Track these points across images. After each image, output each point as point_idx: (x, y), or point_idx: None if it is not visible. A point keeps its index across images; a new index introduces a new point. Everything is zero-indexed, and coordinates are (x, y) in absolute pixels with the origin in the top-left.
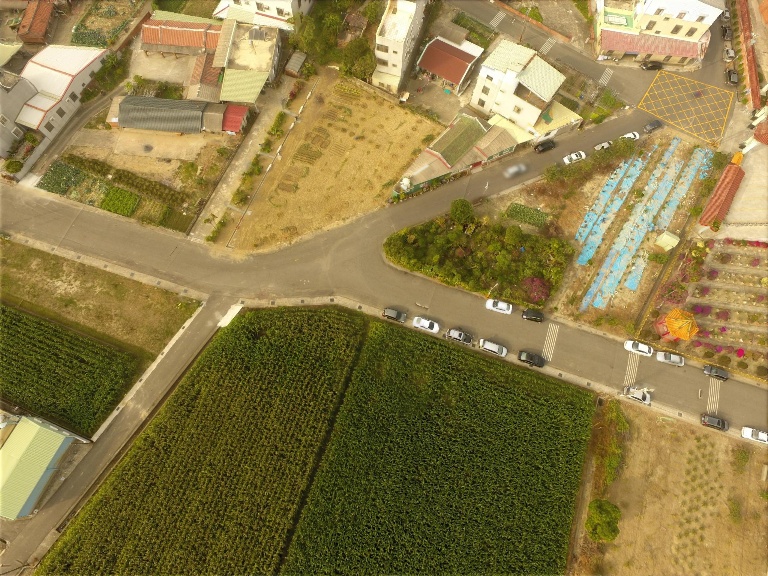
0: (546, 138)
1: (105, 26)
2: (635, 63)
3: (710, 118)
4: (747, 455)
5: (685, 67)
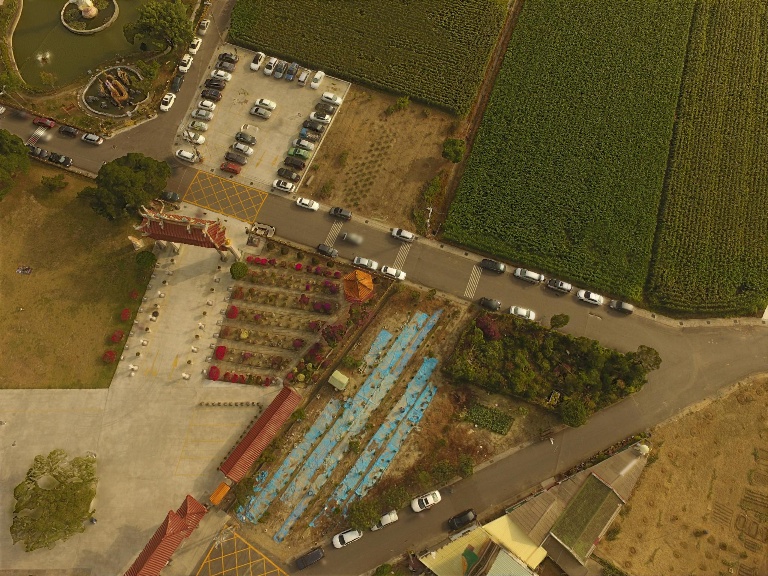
0: None
1: None
2: None
3: None
4: (324, 190)
5: None
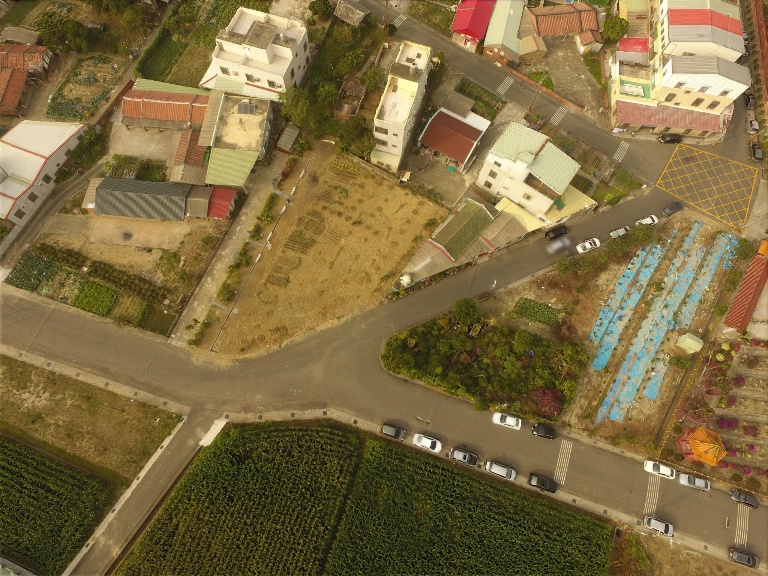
0: (558, 223)
1: (84, 95)
2: (652, 135)
3: (733, 198)
4: None
5: (706, 140)
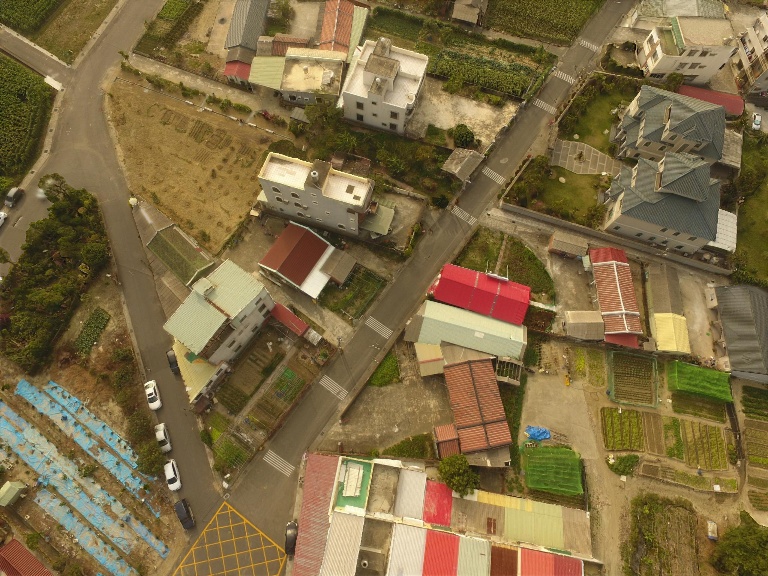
0: None
1: None
2: None
3: None
4: None
5: None
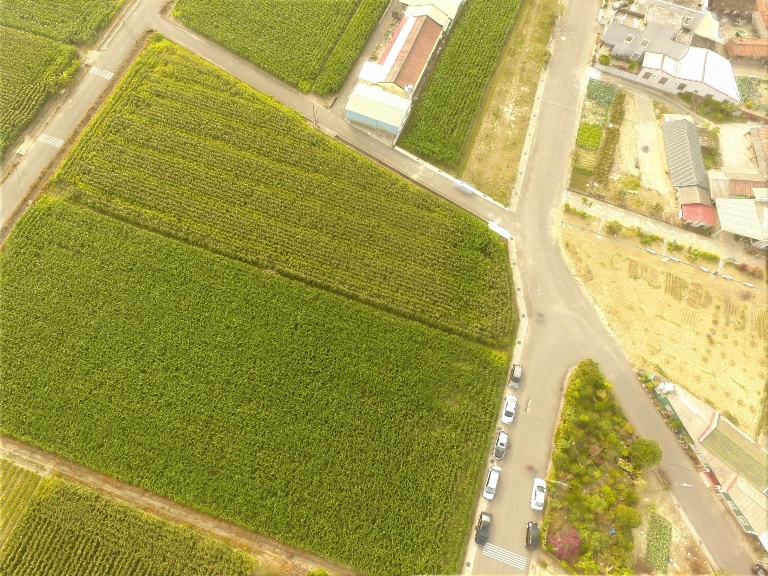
0: None
1: (766, 98)
2: None
3: None
4: None
5: None
